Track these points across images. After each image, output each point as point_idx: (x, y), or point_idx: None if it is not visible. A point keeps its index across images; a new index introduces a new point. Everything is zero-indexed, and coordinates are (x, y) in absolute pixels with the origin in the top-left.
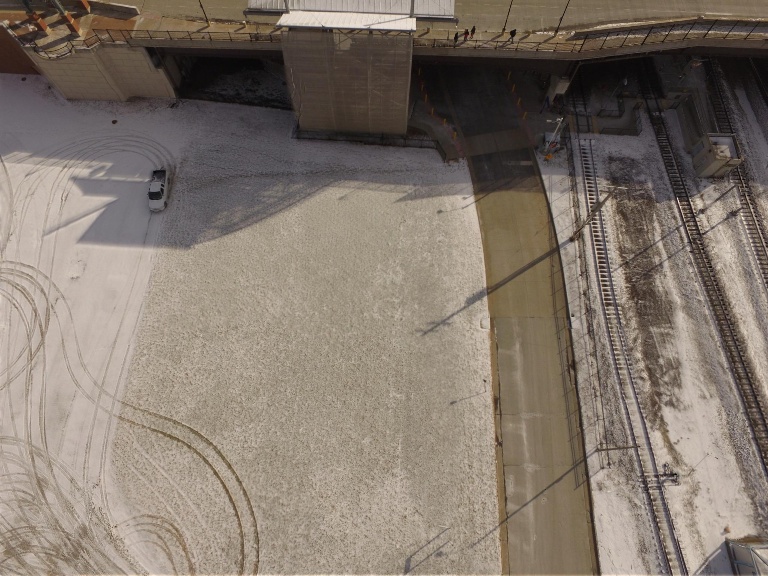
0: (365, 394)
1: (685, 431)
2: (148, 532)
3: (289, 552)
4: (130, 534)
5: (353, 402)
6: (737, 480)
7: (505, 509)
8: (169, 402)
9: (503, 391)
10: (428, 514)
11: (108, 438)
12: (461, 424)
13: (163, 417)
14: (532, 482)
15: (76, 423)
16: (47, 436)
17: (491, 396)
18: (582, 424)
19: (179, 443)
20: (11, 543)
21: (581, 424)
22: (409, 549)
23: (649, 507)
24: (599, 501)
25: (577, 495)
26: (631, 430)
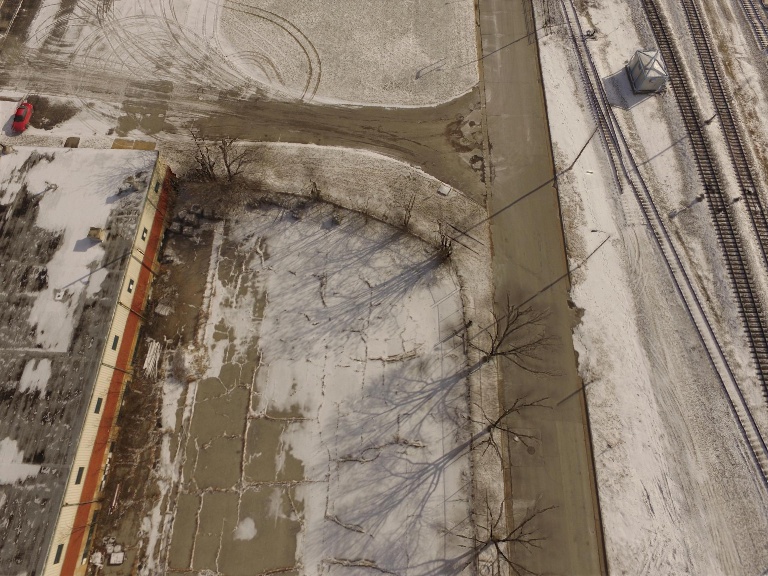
0: (388, 0)
1: (603, 18)
2: (248, 59)
3: (341, 68)
4: (236, 60)
5: (380, 3)
6: (635, 39)
7: (482, 54)
8: (256, 0)
9: (481, 1)
10: (431, 53)
11: (217, 16)
12: (452, 13)
13: (253, 7)
14: (500, 42)
15: (195, 9)
16: (176, 15)
17: (473, 2)
18: (534, 15)
19: (264, 19)
20: (159, 63)
21: (533, 15)
22: (419, 68)
23: (576, 49)
24: (544, 50)
25: (529, 48)
26: (566, 15)
